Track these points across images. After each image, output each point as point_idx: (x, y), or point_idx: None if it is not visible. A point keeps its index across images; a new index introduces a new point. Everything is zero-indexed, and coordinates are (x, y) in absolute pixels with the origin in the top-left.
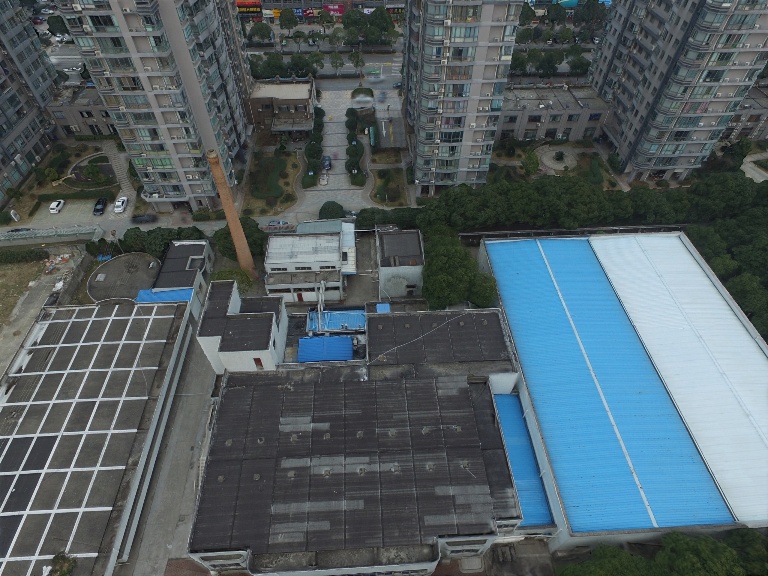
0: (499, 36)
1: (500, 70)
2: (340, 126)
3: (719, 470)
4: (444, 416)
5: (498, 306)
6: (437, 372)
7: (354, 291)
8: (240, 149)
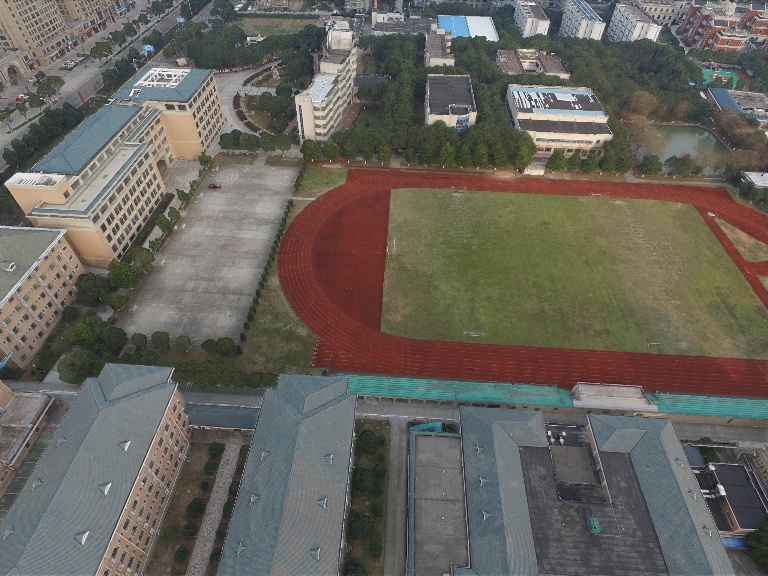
0: None
1: None
2: (401, 3)
3: (472, 37)
4: None
5: (437, 21)
6: None
7: None
8: None
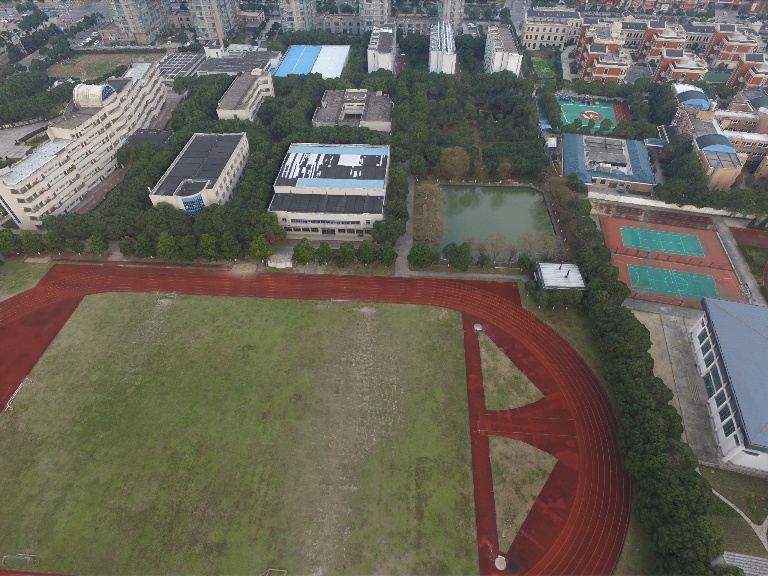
0: None
1: None
2: None
3: None
4: None
5: None
6: None
7: None
8: (231, 30)
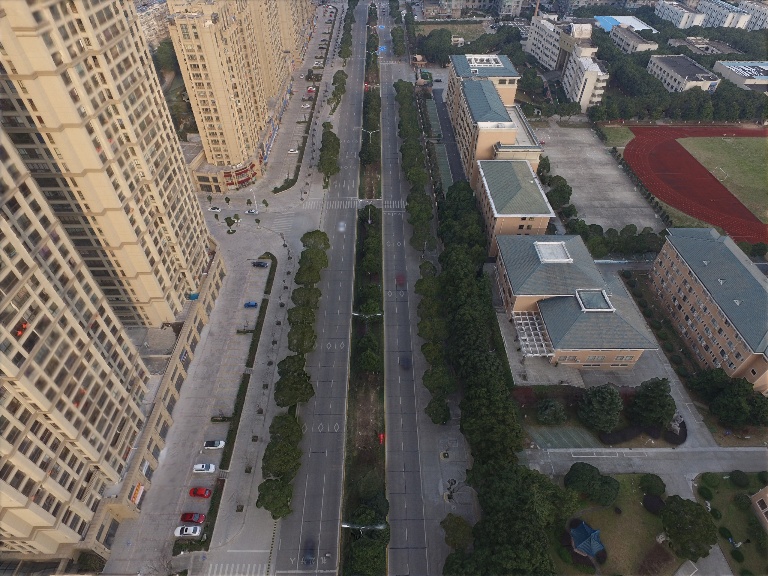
0: None
1: None
2: None
3: None
4: None
5: None
6: None
7: None
8: None
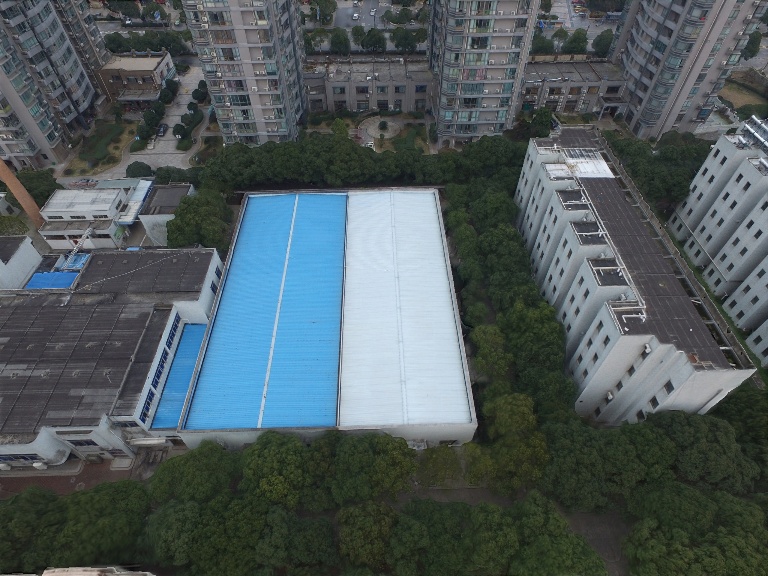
0: (249, 1)
1: (261, 34)
2: None
3: (347, 386)
4: (113, 334)
5: (226, 249)
6: (132, 300)
7: (134, 241)
8: (79, 116)
